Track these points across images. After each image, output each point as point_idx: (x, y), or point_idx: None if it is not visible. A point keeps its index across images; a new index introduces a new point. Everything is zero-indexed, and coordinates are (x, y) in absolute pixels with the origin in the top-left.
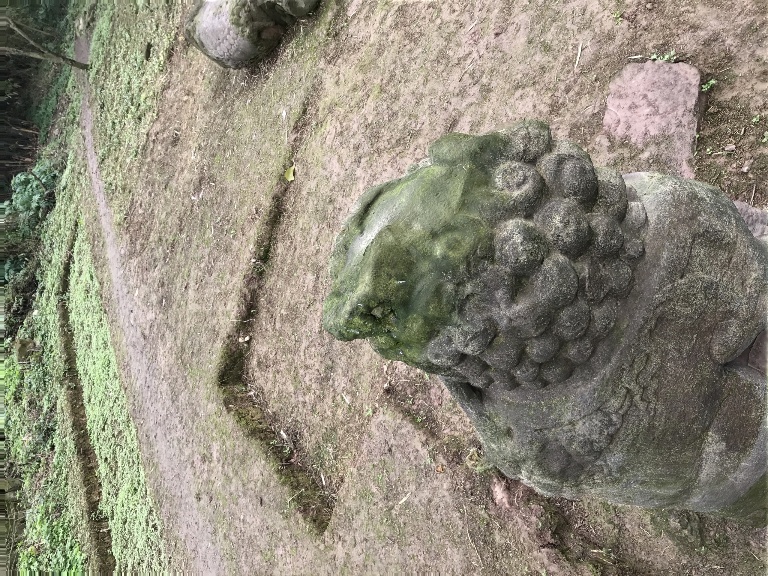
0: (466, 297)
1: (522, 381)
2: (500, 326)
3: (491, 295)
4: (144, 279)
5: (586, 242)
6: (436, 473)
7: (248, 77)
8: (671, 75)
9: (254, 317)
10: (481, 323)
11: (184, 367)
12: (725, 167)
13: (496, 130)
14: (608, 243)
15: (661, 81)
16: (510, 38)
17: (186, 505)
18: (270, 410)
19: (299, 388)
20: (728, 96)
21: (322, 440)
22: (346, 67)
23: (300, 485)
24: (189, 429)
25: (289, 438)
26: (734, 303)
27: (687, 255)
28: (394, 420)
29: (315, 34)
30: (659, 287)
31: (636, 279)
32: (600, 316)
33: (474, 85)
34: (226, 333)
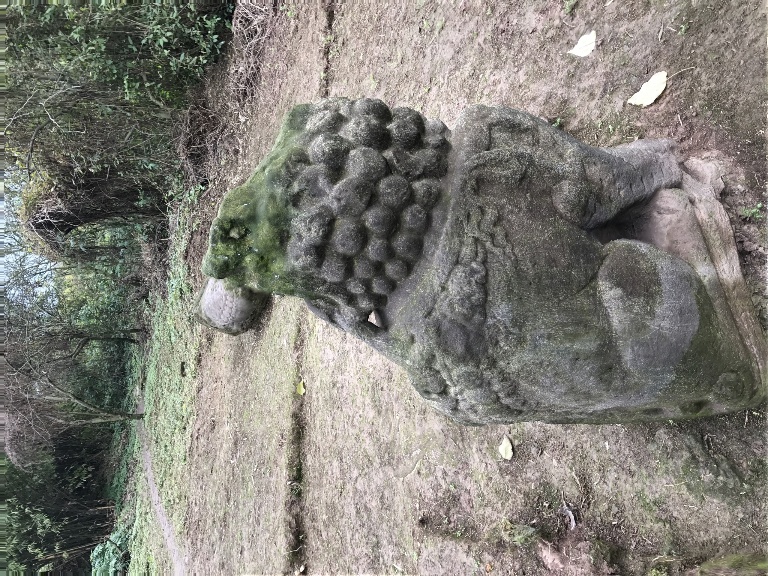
0: (297, 194)
1: (388, 268)
2: (333, 209)
3: (316, 187)
4: (206, 571)
5: (382, 134)
6: (487, 575)
7: (255, 336)
8: None
9: (304, 543)
10: None
11: None
12: None
13: None
14: (402, 132)
15: None
16: None
17: None
18: None
19: None
20: (575, 123)
21: None
22: None
23: None
24: None
25: None
26: (556, 168)
27: (486, 136)
28: (435, 546)
29: None
30: (466, 157)
31: (449, 162)
32: (420, 185)
33: None
34: (281, 572)
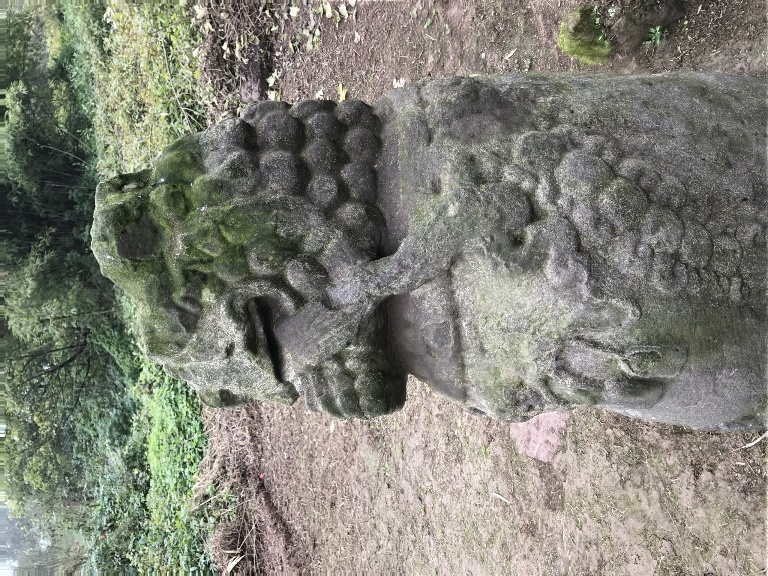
0: None
1: (348, 146)
2: None
3: None
4: None
5: None
6: None
7: None
8: None
9: None
10: None
11: None
12: None
13: None
14: None
15: None
16: None
17: None
18: None
19: None
20: None
21: None
22: None
23: None
24: None
25: None
26: None
27: None
28: None
29: None
30: None
31: None
32: None
33: None
34: None
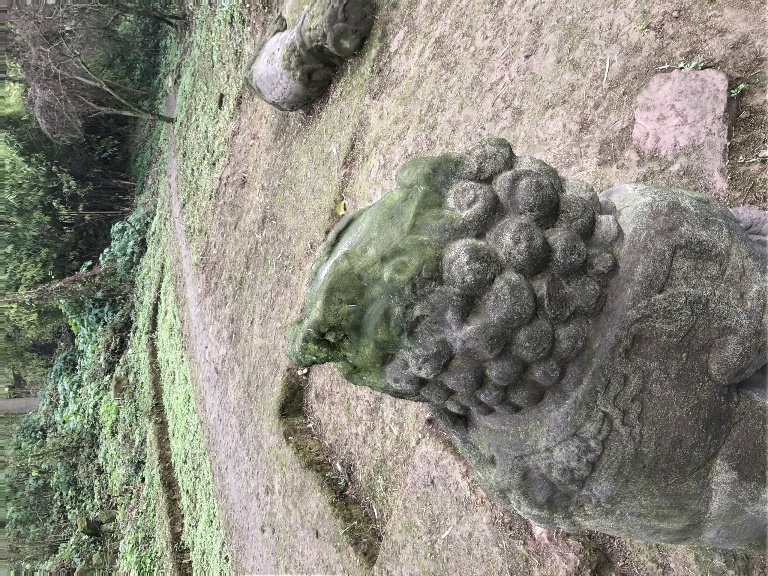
0: (416, 319)
1: None
2: (454, 348)
3: (442, 316)
4: (217, 316)
5: (542, 258)
6: (476, 506)
7: (304, 118)
8: (698, 82)
9: None
10: (433, 345)
11: (250, 400)
12: (759, 174)
13: (528, 152)
14: (567, 258)
15: (688, 89)
16: (540, 59)
17: (252, 537)
18: (327, 442)
19: (352, 419)
20: (760, 99)
21: (373, 472)
22: (388, 101)
23: (353, 518)
24: (255, 461)
25: (343, 470)
26: (731, 318)
27: (666, 268)
28: (435, 451)
29: (361, 72)
30: (633, 303)
31: (609, 295)
32: (565, 335)
33: (506, 109)
34: (286, 366)
